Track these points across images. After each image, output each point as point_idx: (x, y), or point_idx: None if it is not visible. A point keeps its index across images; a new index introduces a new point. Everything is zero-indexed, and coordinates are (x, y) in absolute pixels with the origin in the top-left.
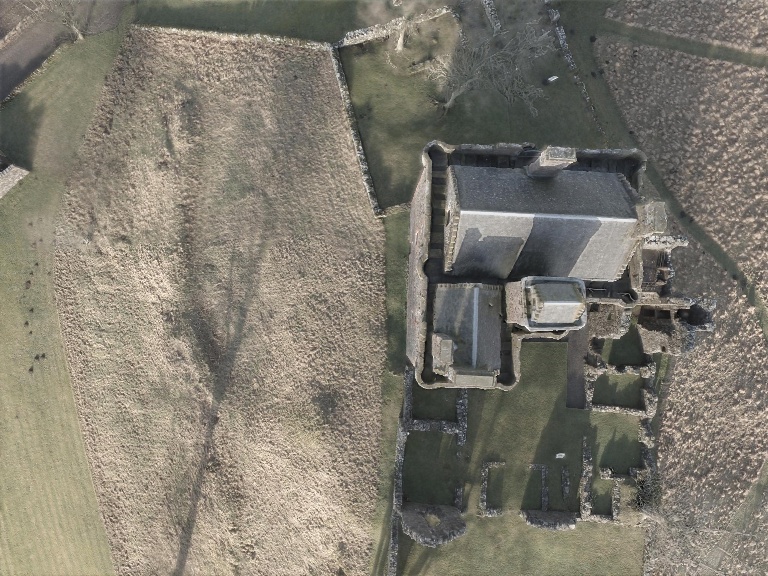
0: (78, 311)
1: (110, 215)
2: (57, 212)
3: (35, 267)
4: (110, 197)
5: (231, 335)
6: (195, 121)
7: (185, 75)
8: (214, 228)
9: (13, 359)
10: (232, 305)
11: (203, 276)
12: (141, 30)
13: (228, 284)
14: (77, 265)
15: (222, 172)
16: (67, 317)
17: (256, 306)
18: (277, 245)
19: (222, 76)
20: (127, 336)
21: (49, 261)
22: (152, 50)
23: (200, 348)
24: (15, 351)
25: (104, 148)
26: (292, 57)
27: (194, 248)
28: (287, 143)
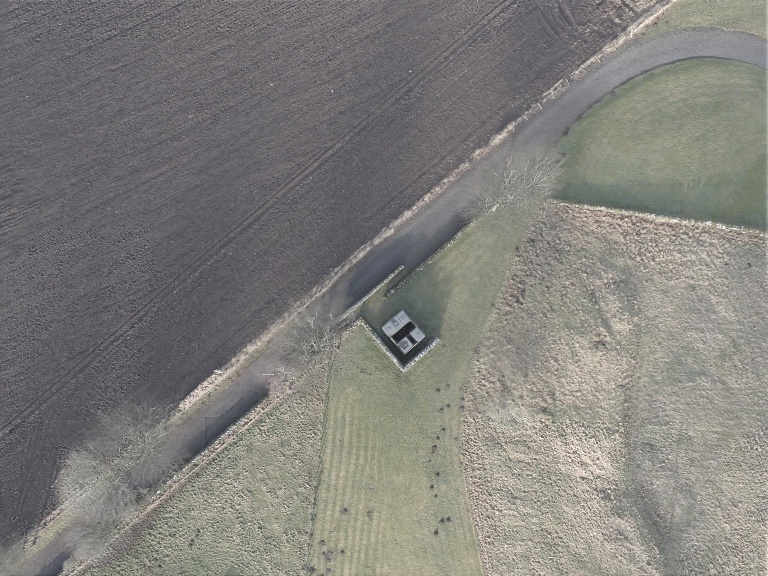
0: (486, 476)
1: (528, 386)
2: (465, 379)
3: (442, 432)
4: (527, 368)
5: (677, 517)
6: (632, 302)
7: (610, 252)
8: (652, 407)
9: (417, 521)
10: (679, 487)
11: (642, 455)
12: (559, 204)
13: (673, 466)
14: (486, 431)
15: (660, 352)
16: (474, 482)
17: (711, 492)
18: (744, 436)
19: (657, 257)
20: (545, 505)
21: (456, 426)
22: (570, 224)
23: (647, 530)
24: (419, 513)
25: (516, 317)
26: (744, 244)
27: (631, 426)
28: (747, 332)
